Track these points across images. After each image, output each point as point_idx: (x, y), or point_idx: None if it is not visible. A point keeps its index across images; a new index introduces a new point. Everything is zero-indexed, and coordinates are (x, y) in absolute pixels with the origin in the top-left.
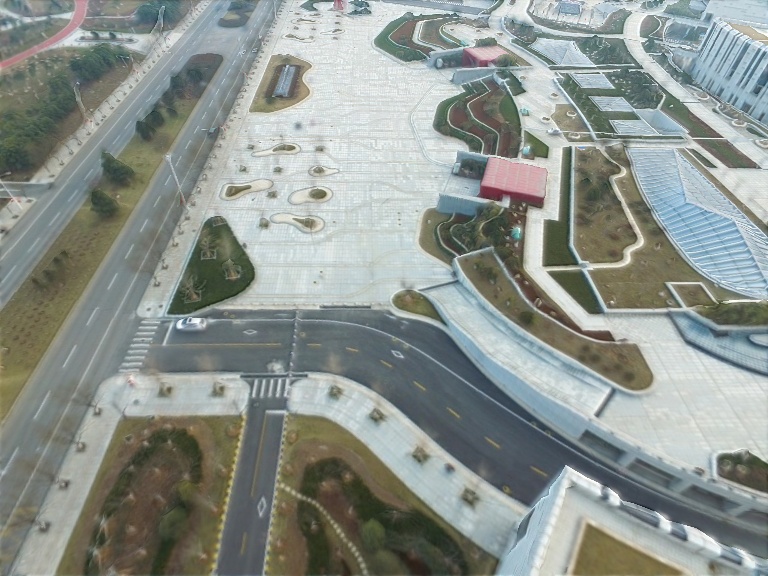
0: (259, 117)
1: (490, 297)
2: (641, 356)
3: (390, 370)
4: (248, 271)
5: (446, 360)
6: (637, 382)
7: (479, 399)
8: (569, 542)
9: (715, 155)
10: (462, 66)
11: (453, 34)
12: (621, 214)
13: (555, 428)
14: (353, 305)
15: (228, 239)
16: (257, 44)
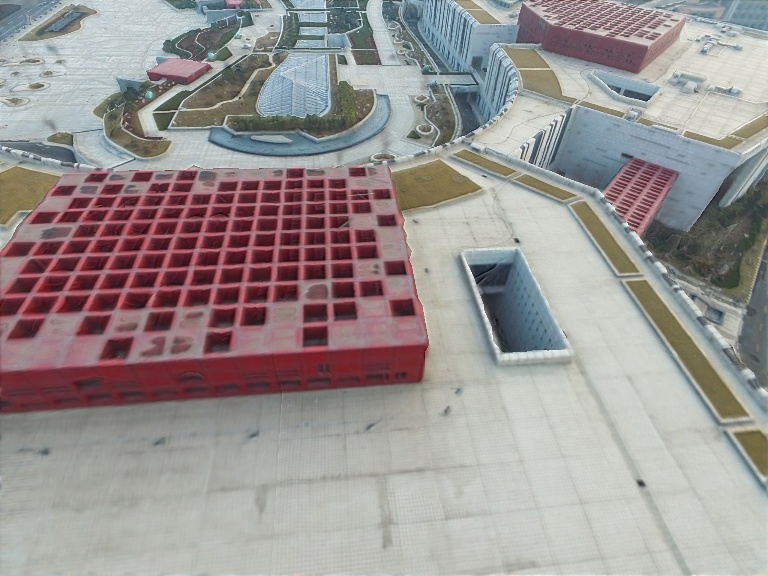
0: (24, 44)
1: (107, 129)
2: (168, 145)
3: None
4: None
5: None
6: (152, 155)
7: None
8: None
9: (356, 58)
10: None
11: None
12: (240, 86)
13: None
14: (17, 140)
15: None
16: None
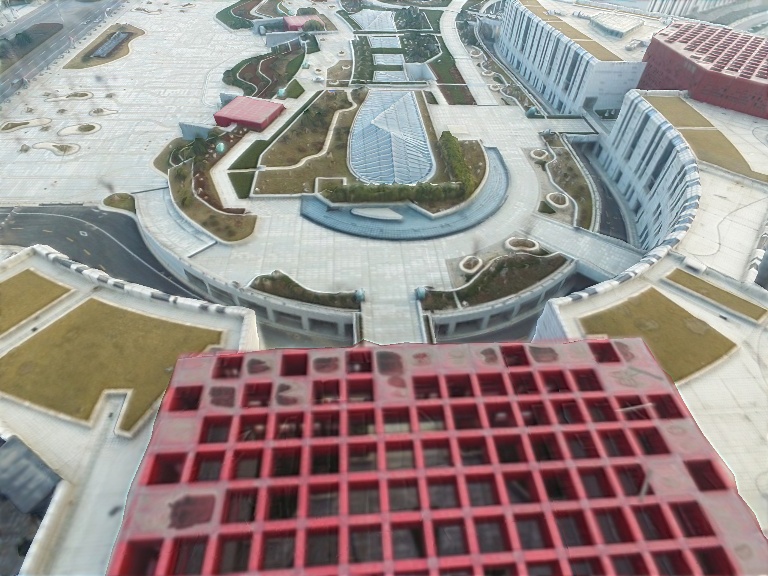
0: (69, 72)
1: (175, 192)
2: (254, 222)
3: (70, 243)
4: None
5: (121, 236)
6: (237, 237)
7: (130, 259)
8: (5, 277)
9: (445, 96)
10: None
11: (289, 7)
12: (323, 135)
13: (177, 275)
14: (68, 203)
15: None
16: (101, 15)
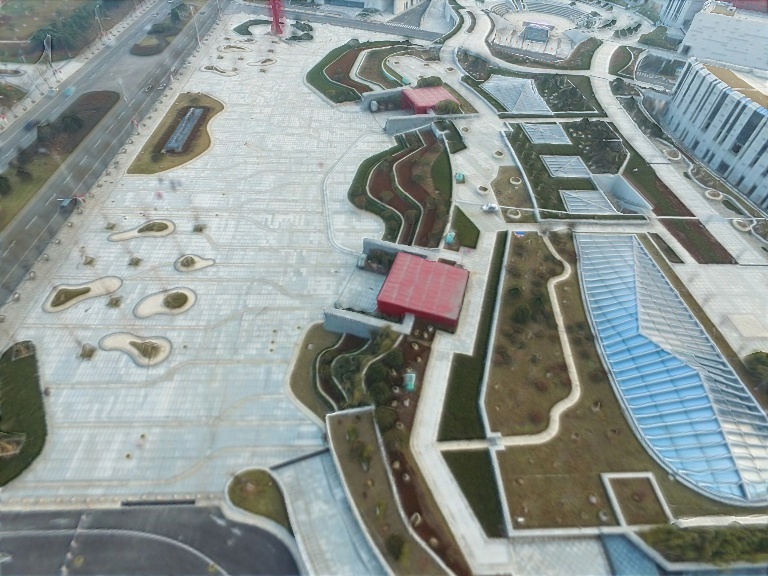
0: (136, 181)
1: (357, 495)
2: None
3: None
4: (35, 440)
5: None
6: None
7: None
8: None
9: (683, 243)
10: (401, 109)
11: (397, 68)
12: (555, 344)
13: None
14: (170, 498)
15: (25, 382)
16: (166, 79)
